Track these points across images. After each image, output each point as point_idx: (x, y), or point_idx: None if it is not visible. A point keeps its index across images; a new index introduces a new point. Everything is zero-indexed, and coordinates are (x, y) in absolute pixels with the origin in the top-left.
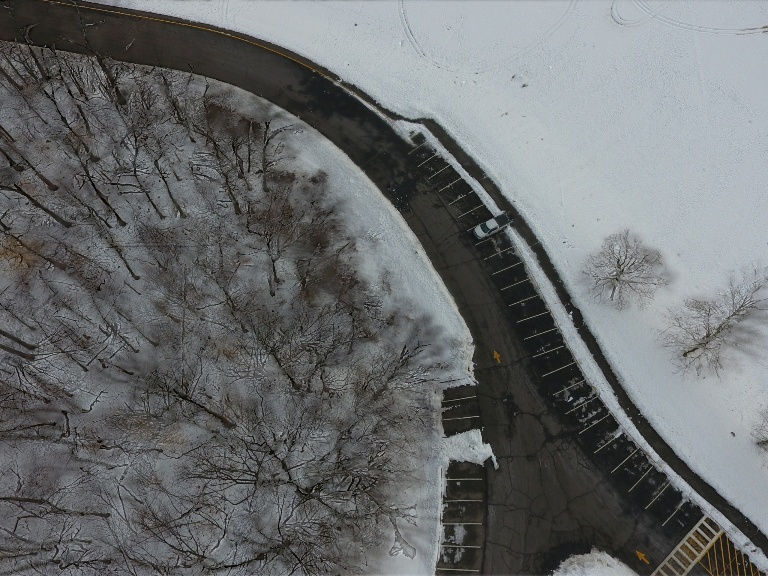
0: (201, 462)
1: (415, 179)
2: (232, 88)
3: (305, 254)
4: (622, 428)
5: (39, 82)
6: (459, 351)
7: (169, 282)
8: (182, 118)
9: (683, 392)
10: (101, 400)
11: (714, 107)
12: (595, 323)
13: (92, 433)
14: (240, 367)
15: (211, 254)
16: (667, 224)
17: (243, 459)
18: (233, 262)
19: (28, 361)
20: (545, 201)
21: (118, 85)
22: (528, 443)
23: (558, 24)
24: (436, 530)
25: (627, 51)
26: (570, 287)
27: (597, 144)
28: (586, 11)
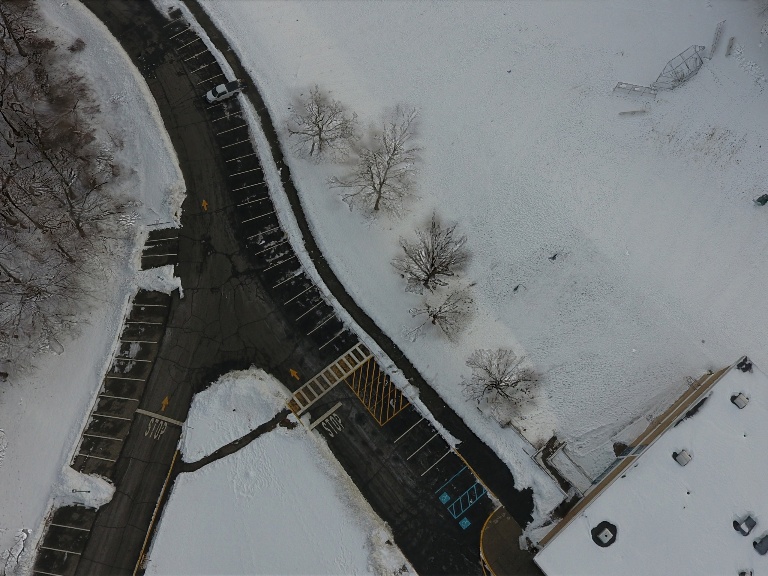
0: None
1: (165, 49)
2: None
3: (49, 112)
4: (303, 268)
5: None
6: (168, 198)
7: None
8: None
9: (366, 239)
10: None
11: None
12: (300, 178)
13: None
14: None
15: None
16: (400, 101)
17: None
18: None
19: None
20: (280, 72)
21: None
22: (215, 278)
23: None
24: (112, 345)
25: None
26: (284, 147)
27: (352, 28)
28: None
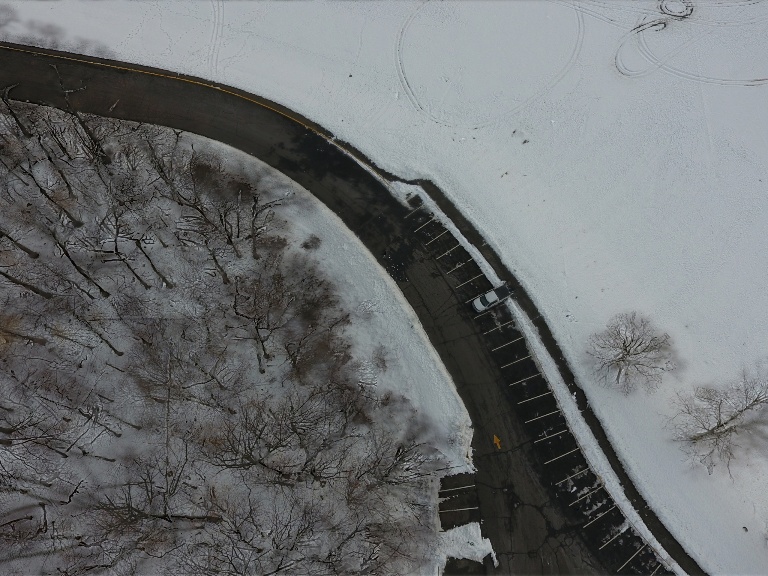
0: (185, 562)
1: (411, 245)
2: (221, 146)
3: (296, 327)
4: (628, 522)
5: None
6: (457, 436)
7: (154, 359)
8: (169, 179)
9: (692, 482)
10: (80, 491)
11: (723, 164)
12: (600, 405)
13: (70, 530)
14: (227, 455)
15: (198, 328)
16: (674, 293)
17: (229, 558)
18: (221, 336)
19: (5, 446)
20: (547, 270)
21: (102, 145)
22: (529, 538)
23: (560, 75)
24: None
25: (632, 104)
26: (573, 365)
27: (601, 205)
28: (589, 61)
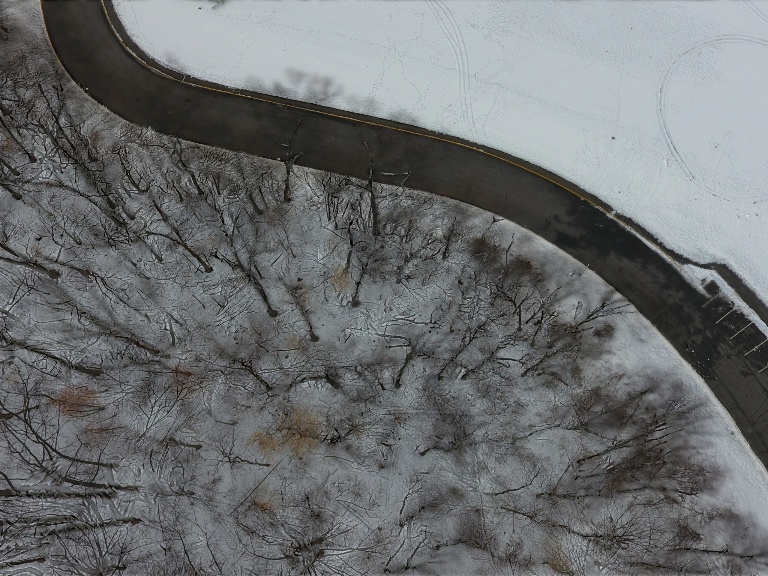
0: None
1: (715, 339)
2: None
3: (604, 428)
4: None
5: (280, 205)
6: None
7: (460, 460)
8: (446, 255)
9: None
10: None
11: None
12: None
13: None
14: None
15: (501, 426)
16: None
17: None
18: None
19: (318, 557)
20: None
21: (377, 217)
22: None
23: None
24: None
25: None
26: None
27: None
28: None
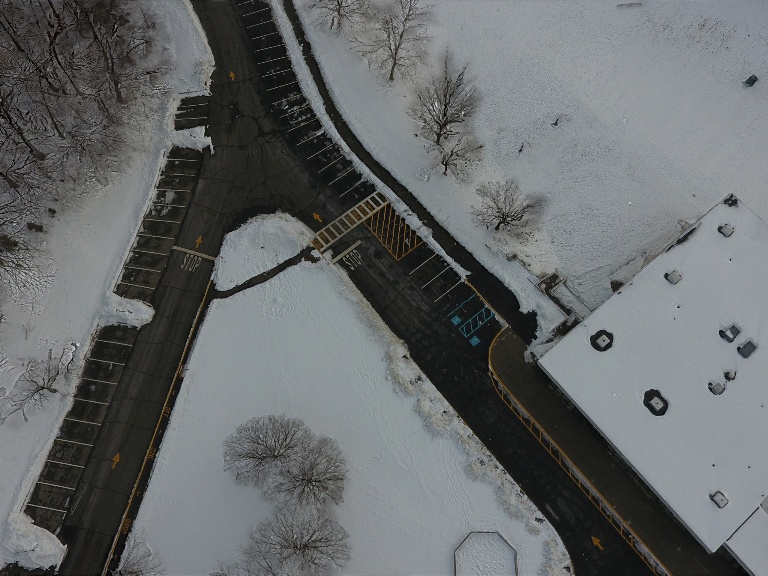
0: None
1: None
2: None
3: None
4: (324, 128)
5: None
6: (199, 68)
7: None
8: None
9: (382, 104)
10: None
11: None
12: (320, 53)
13: None
14: (7, 71)
15: None
16: None
17: None
18: (22, 1)
19: None
20: None
21: None
22: (243, 137)
23: None
24: (149, 191)
25: None
26: (306, 26)
27: None
28: None
